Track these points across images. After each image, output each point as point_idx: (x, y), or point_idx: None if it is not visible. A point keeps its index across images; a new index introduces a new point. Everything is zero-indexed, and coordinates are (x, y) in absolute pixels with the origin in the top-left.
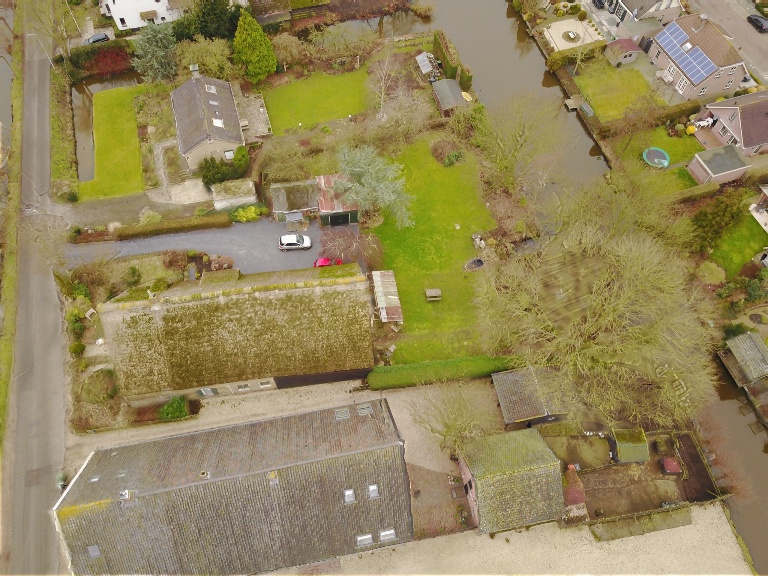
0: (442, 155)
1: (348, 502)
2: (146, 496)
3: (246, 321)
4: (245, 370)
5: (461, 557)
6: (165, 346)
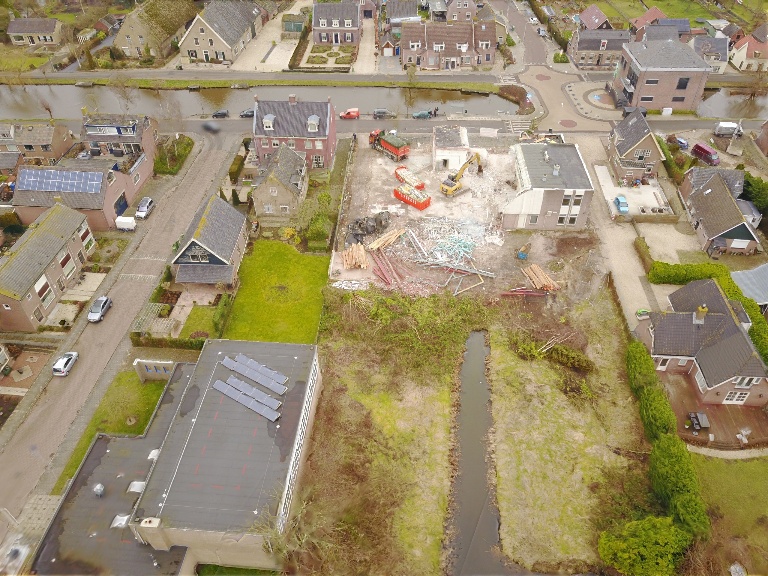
0: (124, 8)
1: (241, 1)
2: (209, 6)
3: (163, 6)
4: (178, 23)
5: (274, 23)
6: (154, 21)
